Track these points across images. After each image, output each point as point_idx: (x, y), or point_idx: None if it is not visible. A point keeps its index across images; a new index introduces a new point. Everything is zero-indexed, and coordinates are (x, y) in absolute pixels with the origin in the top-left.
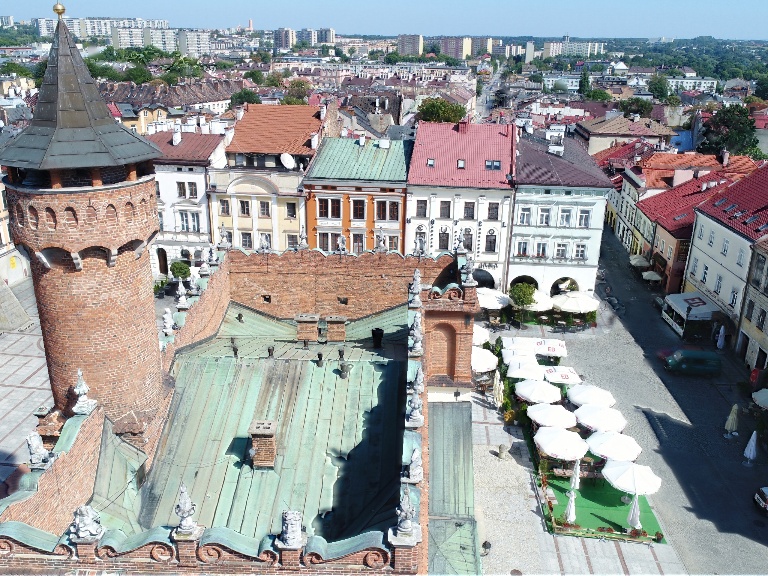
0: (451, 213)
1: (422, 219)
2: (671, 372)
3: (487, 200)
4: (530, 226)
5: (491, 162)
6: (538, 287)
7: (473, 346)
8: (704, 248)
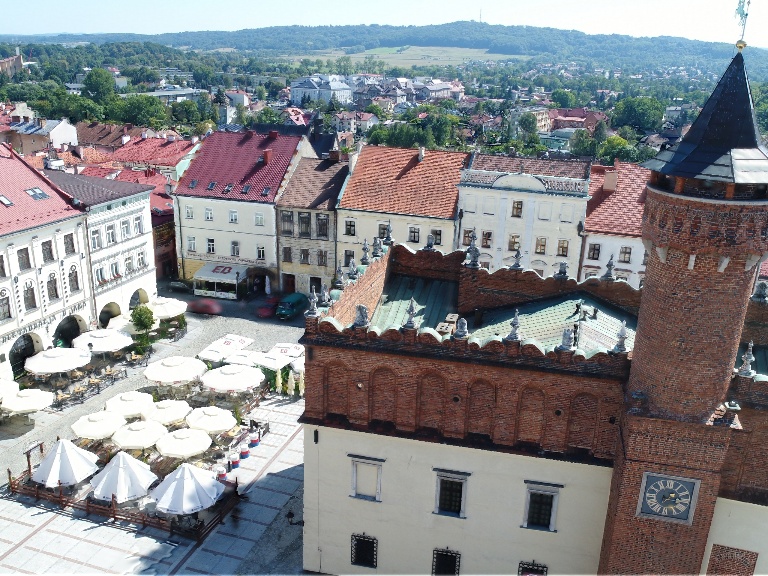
0: (31, 262)
1: (2, 281)
2: (290, 319)
3: (62, 234)
4: (103, 249)
5: (31, 191)
6: (120, 310)
7: (232, 364)
8: (201, 225)
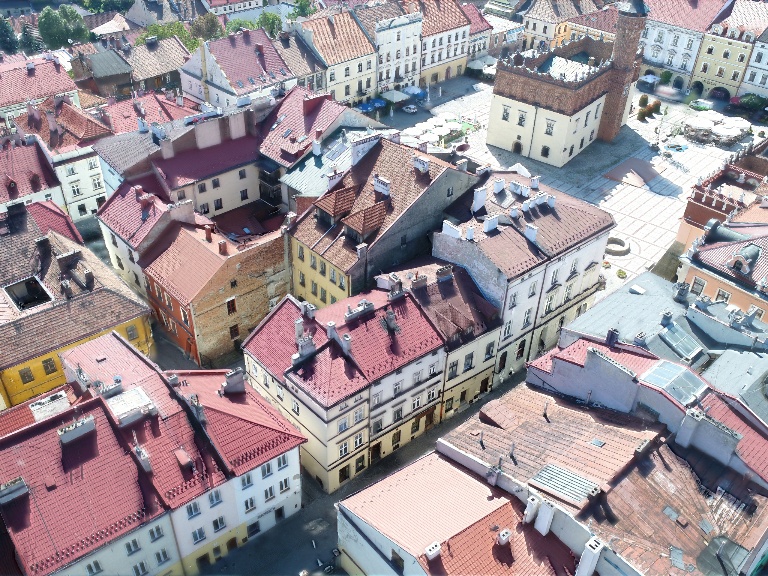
0: None
1: None
2: None
3: None
4: None
5: None
6: None
7: None
8: None
